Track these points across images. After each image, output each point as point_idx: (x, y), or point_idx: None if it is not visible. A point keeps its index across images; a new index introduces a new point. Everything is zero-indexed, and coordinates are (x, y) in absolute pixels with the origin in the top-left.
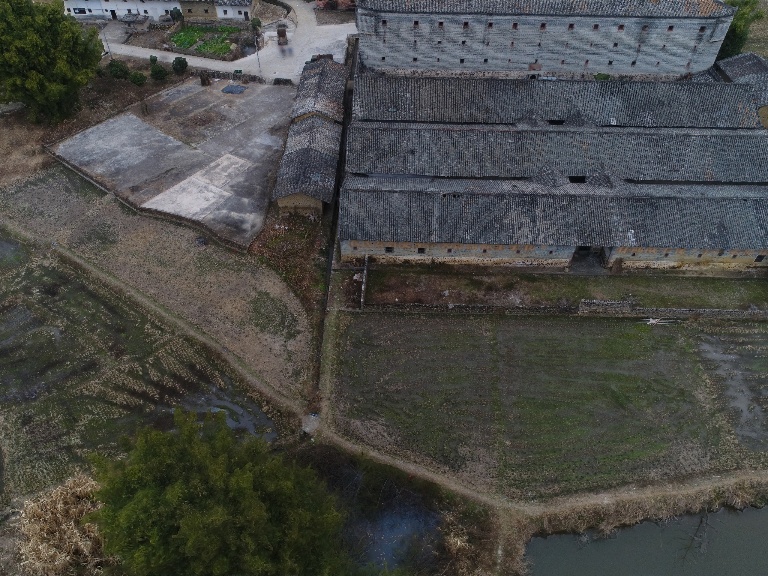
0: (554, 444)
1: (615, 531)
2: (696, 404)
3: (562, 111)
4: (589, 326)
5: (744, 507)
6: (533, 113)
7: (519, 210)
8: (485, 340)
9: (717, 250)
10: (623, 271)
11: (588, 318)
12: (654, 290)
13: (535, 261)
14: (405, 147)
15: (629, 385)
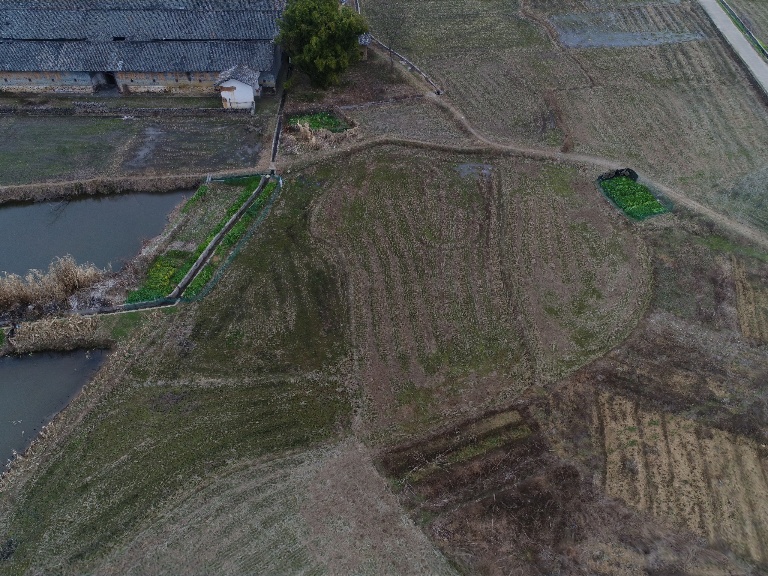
0: (1, 170)
1: (3, 203)
2: (112, 153)
3: (147, 3)
4: (81, 120)
5: (94, 193)
6: (122, 4)
7: (49, 51)
8: (3, 127)
9: (185, 75)
10: (131, 94)
11: (84, 117)
12: (143, 103)
13: (69, 88)
14: (3, 21)
15: (78, 145)
